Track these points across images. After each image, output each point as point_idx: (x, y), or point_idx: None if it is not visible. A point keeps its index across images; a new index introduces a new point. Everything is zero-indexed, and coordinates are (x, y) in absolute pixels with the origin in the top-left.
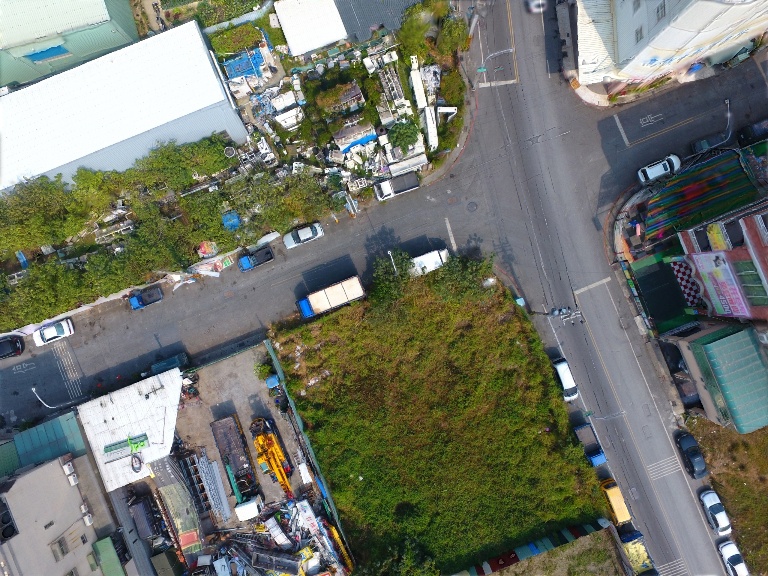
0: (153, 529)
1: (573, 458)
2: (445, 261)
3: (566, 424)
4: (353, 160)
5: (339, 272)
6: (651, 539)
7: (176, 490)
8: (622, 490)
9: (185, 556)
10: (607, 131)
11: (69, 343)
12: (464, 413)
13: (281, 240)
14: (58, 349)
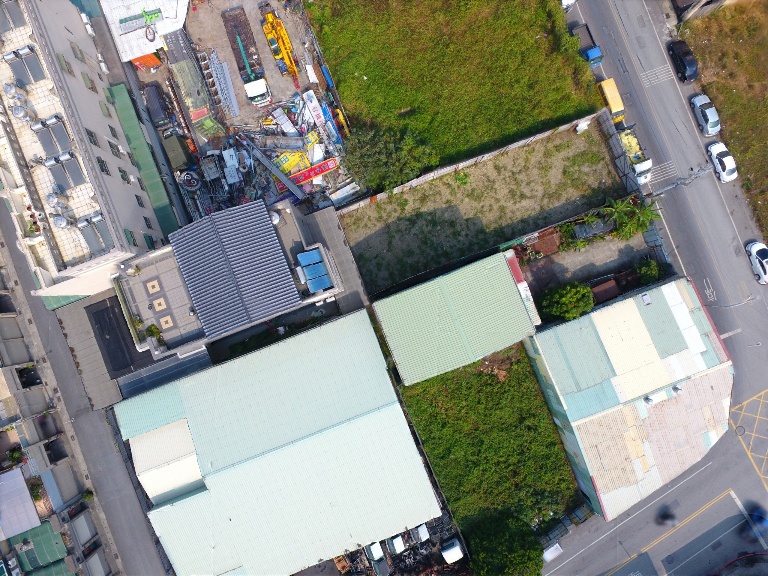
0: (165, 114)
1: (570, 47)
2: None
3: (563, 28)
4: None
5: None
6: (643, 142)
7: (188, 68)
8: None
9: (195, 141)
10: None
11: None
12: (466, 17)
13: None
14: None
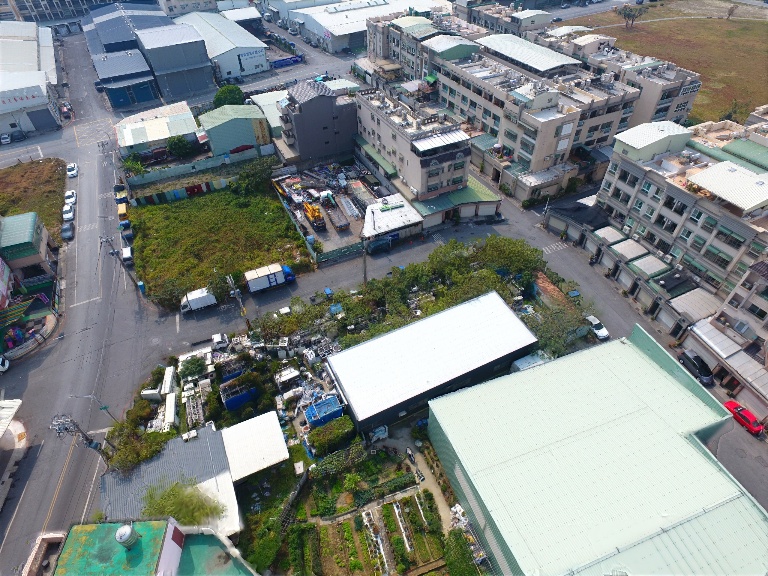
0: None
1: None
2: None
3: None
4: None
5: (266, 298)
6: None
7: None
8: (117, 219)
9: None
10: None
11: None
12: None
13: None
14: None
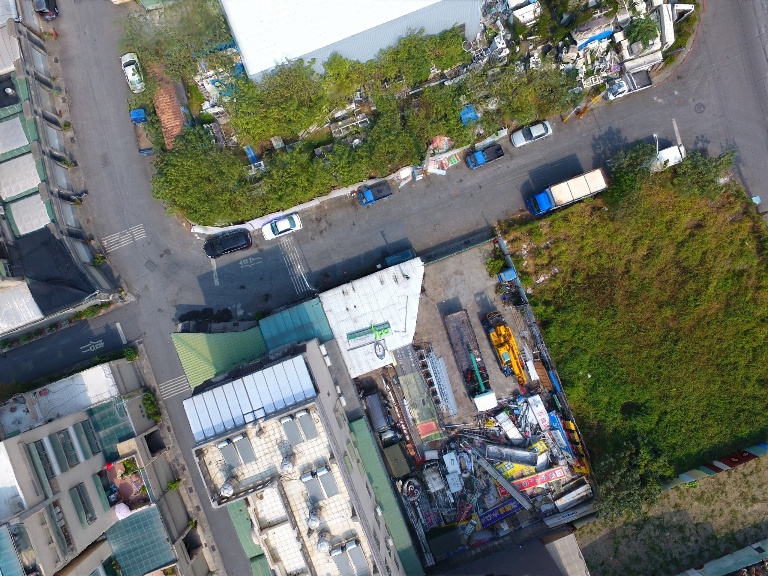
0: (386, 421)
1: None
2: (683, 157)
3: None
4: (585, 58)
5: (565, 171)
6: None
7: (415, 380)
8: None
9: None
10: None
11: (296, 238)
12: (694, 312)
13: (507, 139)
14: (284, 244)
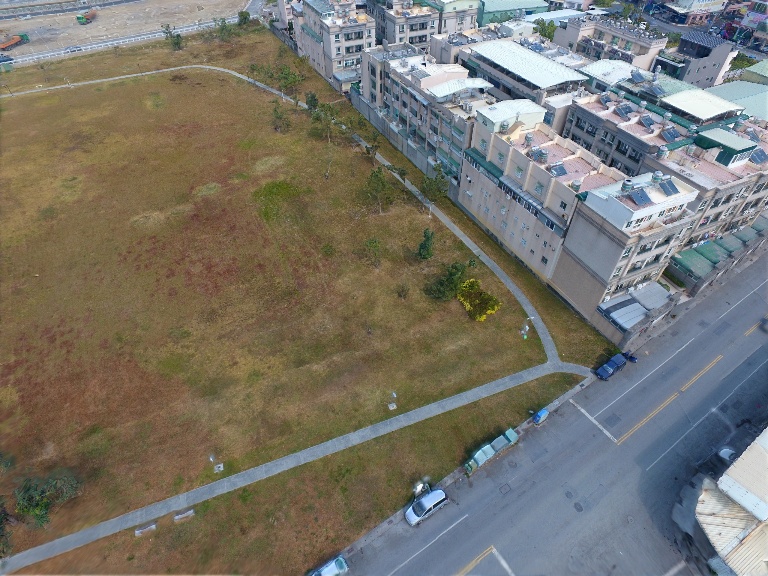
0: None
1: None
2: None
3: None
4: None
5: None
6: None
7: None
8: None
9: None
10: (693, 28)
11: None
12: None
13: None
14: None
